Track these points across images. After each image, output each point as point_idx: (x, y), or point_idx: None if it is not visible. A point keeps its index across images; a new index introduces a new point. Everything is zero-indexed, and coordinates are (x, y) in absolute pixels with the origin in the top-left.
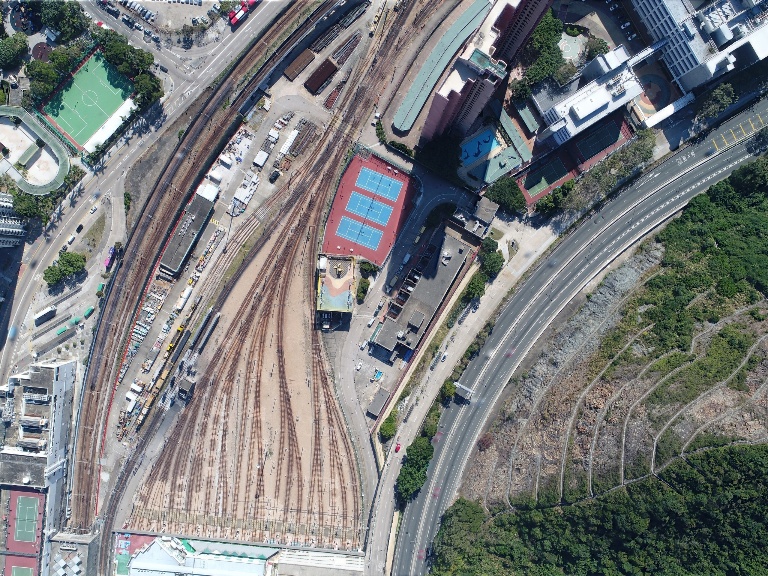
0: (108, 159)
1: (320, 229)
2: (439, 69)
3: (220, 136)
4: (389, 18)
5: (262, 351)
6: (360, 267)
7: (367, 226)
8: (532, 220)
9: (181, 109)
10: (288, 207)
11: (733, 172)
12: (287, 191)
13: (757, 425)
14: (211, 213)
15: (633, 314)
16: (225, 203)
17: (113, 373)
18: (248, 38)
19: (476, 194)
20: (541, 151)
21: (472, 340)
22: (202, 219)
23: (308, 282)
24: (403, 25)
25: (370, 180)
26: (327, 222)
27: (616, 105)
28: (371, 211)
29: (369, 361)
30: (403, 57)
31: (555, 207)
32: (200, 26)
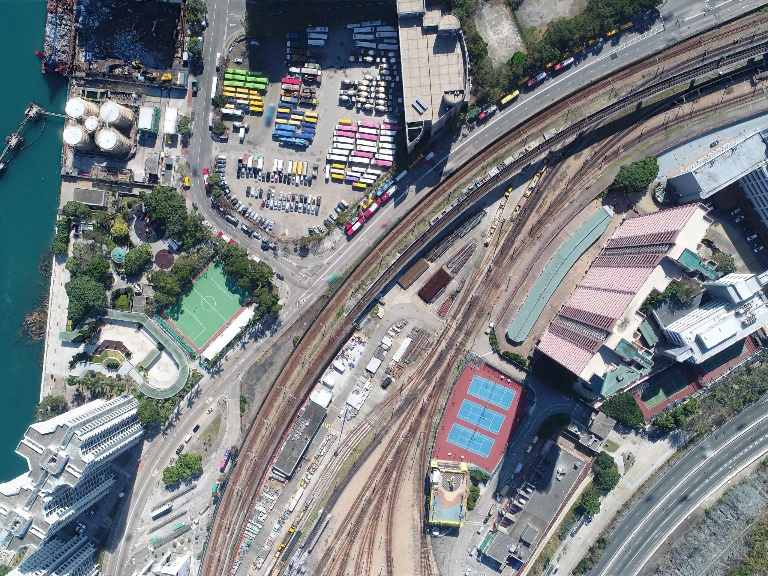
0: (225, 362)
1: (431, 435)
2: (556, 281)
3: (335, 345)
4: (505, 228)
5: (371, 553)
6: (471, 475)
7: (478, 434)
8: (649, 433)
9: (296, 315)
10: (399, 413)
11: None
12: (399, 397)
13: None
14: (323, 417)
15: (761, 549)
16: (337, 407)
17: (225, 569)
18: (363, 247)
19: (591, 407)
20: (659, 363)
21: (584, 553)
22: (315, 425)
23: (418, 487)
24: (519, 235)
25: (482, 388)
26: (438, 428)
27: (745, 332)
28: (483, 419)
29: (478, 567)
30: (518, 266)
31: (675, 426)
32: (317, 238)
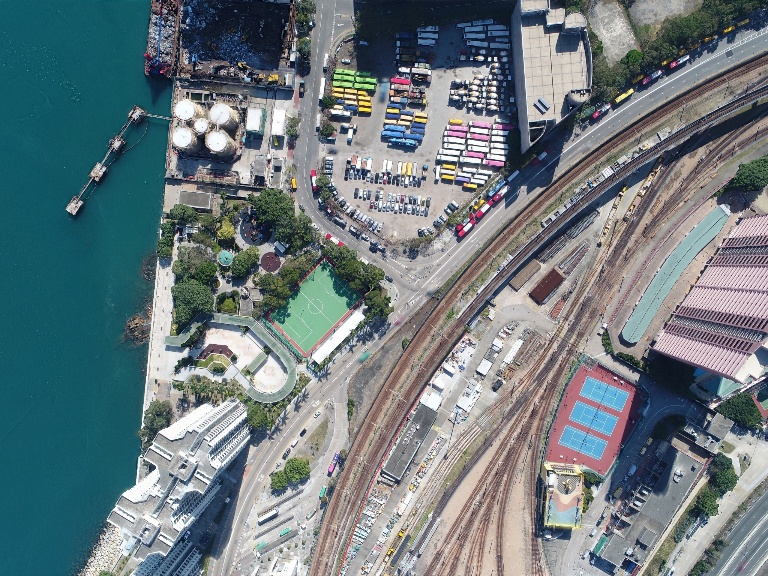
0: (332, 366)
1: (542, 437)
2: (671, 281)
3: (446, 348)
4: (618, 228)
5: (481, 557)
6: (584, 477)
7: (591, 436)
8: (766, 434)
9: (405, 317)
10: (510, 415)
11: None
12: (510, 399)
13: None
14: None
15: None
16: (447, 410)
17: (333, 574)
18: (473, 248)
19: (707, 408)
20: None
21: (700, 555)
22: (426, 428)
23: (529, 490)
24: (632, 235)
25: (595, 390)
26: (550, 431)
27: None
28: (595, 421)
29: (590, 570)
30: (631, 267)
31: None
32: (429, 240)
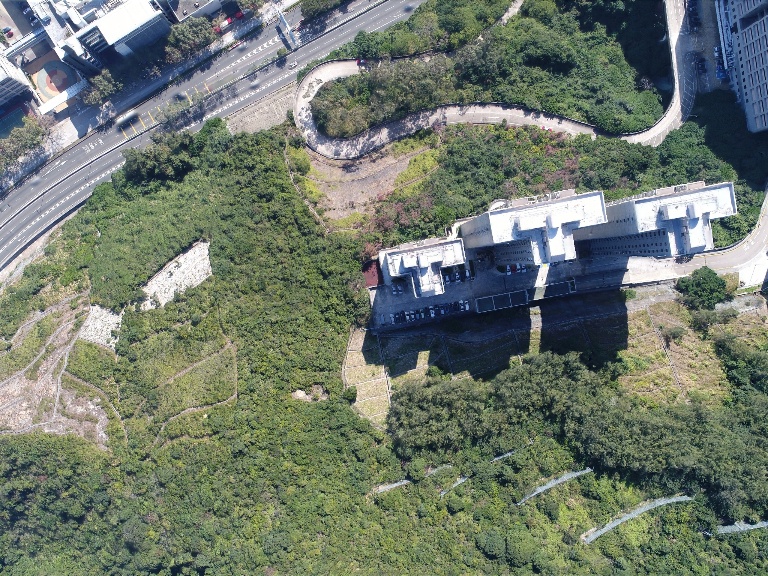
0: None
1: None
2: None
3: None
4: None
5: None
6: None
7: None
8: None
9: None
10: None
11: (126, 160)
12: None
13: (25, 415)
14: None
15: None
16: None
17: None
18: None
19: None
20: None
21: None
22: None
23: None
24: None
25: None
26: None
27: None
28: None
29: None
30: None
31: None
32: None
